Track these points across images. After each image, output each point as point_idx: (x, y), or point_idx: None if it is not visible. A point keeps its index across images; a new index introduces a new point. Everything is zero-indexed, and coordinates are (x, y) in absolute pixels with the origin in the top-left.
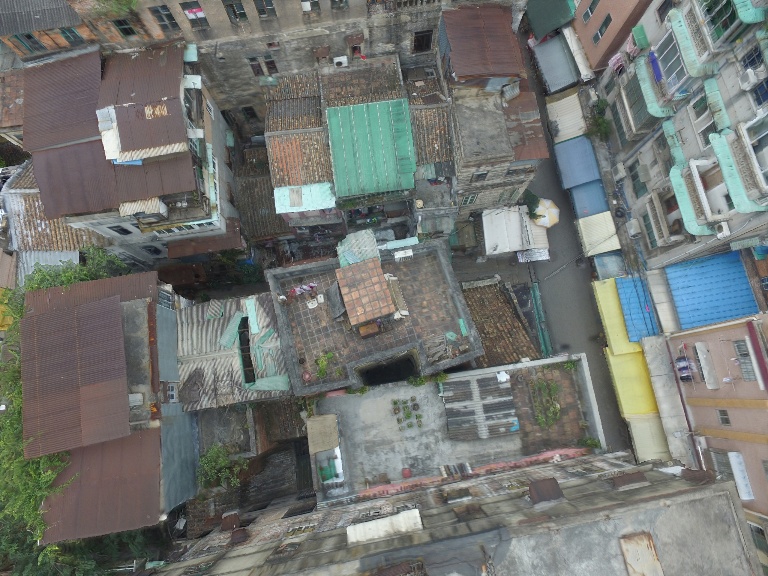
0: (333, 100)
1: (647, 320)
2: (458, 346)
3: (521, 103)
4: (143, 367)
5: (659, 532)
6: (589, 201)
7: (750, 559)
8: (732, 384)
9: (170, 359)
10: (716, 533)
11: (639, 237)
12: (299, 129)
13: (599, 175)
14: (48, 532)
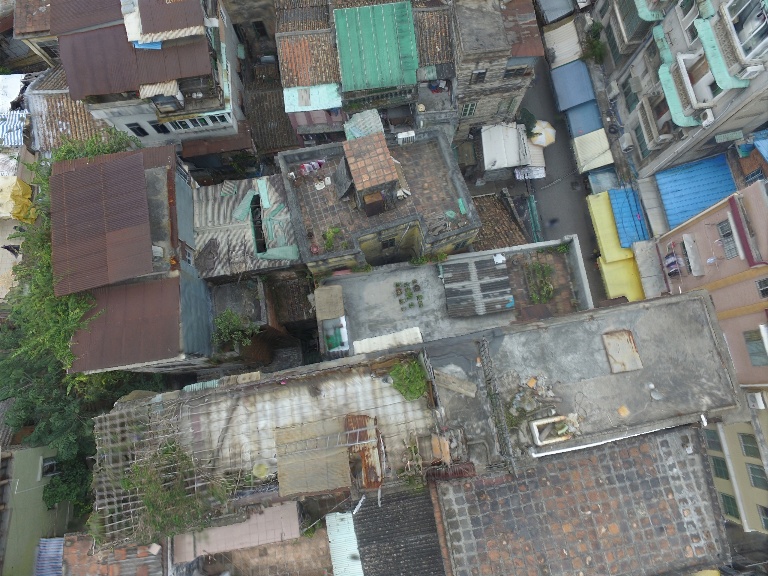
0: (340, 5)
1: (638, 227)
2: (457, 223)
3: (518, 6)
4: (163, 226)
5: (638, 331)
6: (584, 122)
7: (721, 353)
8: (715, 263)
9: (187, 226)
10: (690, 332)
11: (631, 150)
12: (308, 30)
13: (594, 95)
14: (76, 363)
